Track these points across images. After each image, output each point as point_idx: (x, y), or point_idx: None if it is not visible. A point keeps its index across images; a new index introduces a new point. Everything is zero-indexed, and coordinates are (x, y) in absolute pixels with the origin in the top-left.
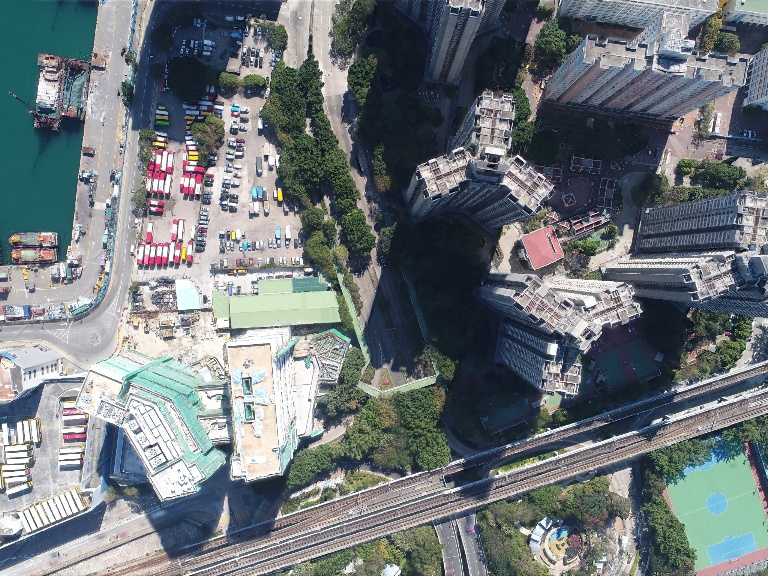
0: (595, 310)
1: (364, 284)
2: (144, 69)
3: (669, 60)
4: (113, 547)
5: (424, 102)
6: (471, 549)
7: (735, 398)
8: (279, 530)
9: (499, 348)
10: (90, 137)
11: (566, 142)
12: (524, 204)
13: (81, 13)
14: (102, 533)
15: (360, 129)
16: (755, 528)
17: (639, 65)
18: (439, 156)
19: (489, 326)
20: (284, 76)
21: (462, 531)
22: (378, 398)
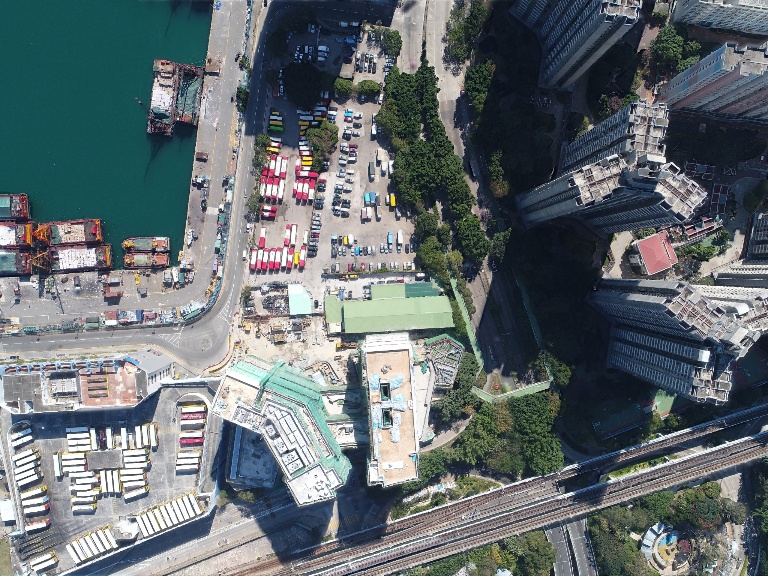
0: (746, 317)
1: (475, 289)
2: (258, 75)
3: None
4: (223, 551)
5: (537, 108)
6: (581, 554)
7: None
8: (391, 535)
9: (611, 353)
10: (203, 142)
11: (680, 148)
12: (677, 211)
13: (194, 19)
14: (211, 537)
15: (475, 135)
16: None
17: None
18: None
19: (600, 331)
20: (401, 82)
21: (572, 536)
22: (492, 403)
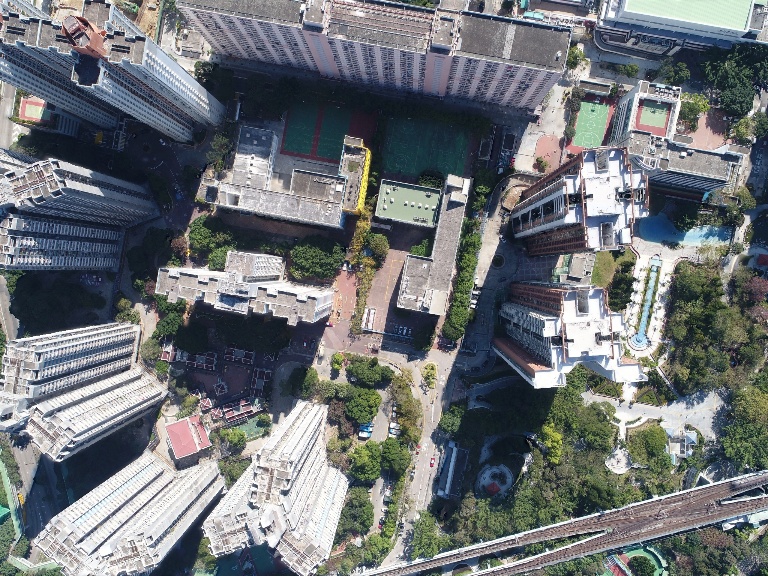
0: (113, 557)
1: (27, 457)
2: None
3: (234, 298)
4: None
5: (87, 285)
6: None
7: None
8: None
9: None
10: None
11: (218, 332)
12: (45, 452)
13: None
14: None
15: None
16: None
17: (211, 298)
18: None
19: None
20: None
21: None
22: (25, 573)
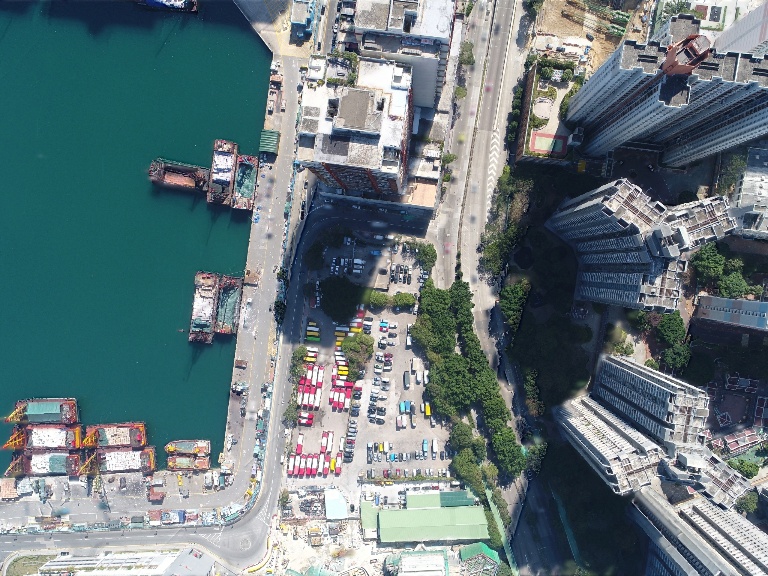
0: None
1: (511, 497)
2: (295, 285)
3: None
4: None
5: (573, 318)
6: None
7: None
8: None
9: (650, 566)
10: (242, 350)
11: (721, 361)
12: (719, 502)
13: (234, 230)
14: None
15: (510, 349)
16: None
17: None
18: None
19: (638, 541)
20: (436, 299)
21: None
22: None
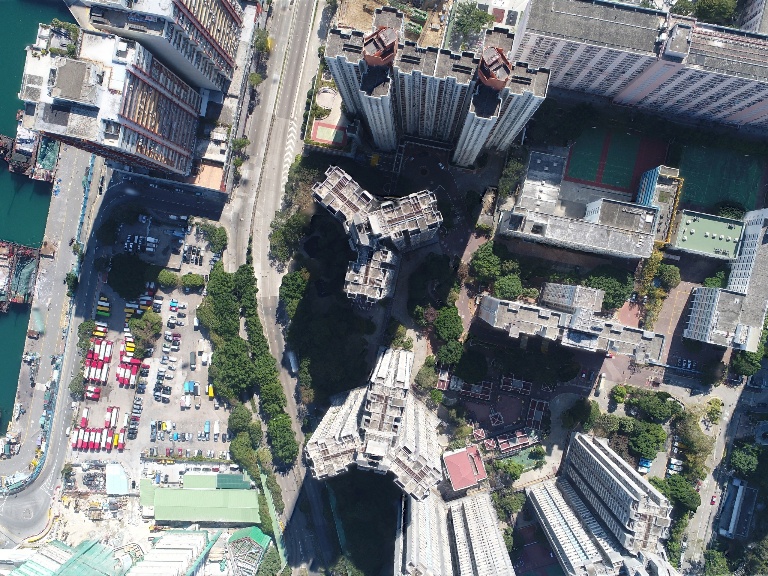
0: None
1: (288, 483)
2: (90, 259)
3: (580, 334)
4: None
5: (358, 310)
6: None
7: None
8: None
9: None
10: (36, 321)
11: (497, 361)
12: (410, 492)
13: (36, 201)
14: None
15: None
16: None
17: (551, 333)
18: (369, 364)
19: None
20: (219, 281)
21: None
22: None
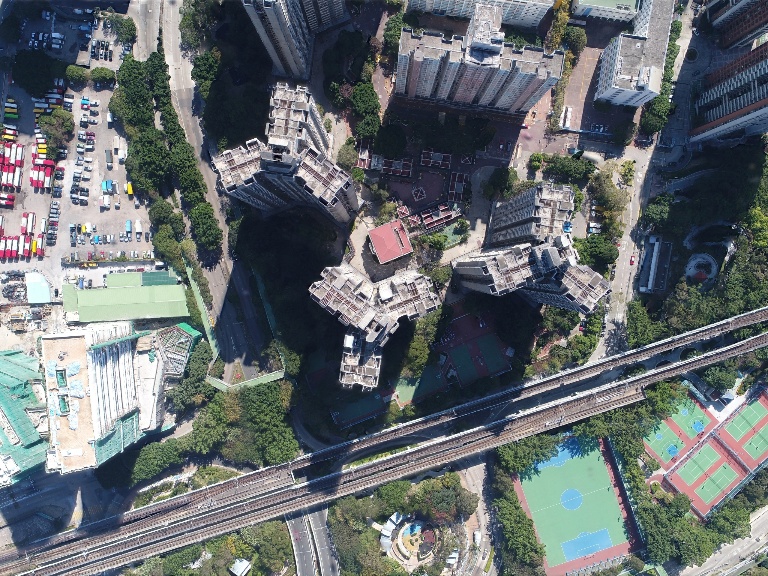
0: (392, 302)
1: (216, 278)
2: None
3: (483, 52)
4: None
5: None
6: (323, 544)
7: (583, 393)
8: (128, 524)
9: None
10: None
11: (415, 136)
12: (319, 196)
13: None
14: None
15: None
16: (610, 524)
17: (455, 57)
18: None
19: None
20: (129, 69)
21: (314, 526)
22: (225, 392)
